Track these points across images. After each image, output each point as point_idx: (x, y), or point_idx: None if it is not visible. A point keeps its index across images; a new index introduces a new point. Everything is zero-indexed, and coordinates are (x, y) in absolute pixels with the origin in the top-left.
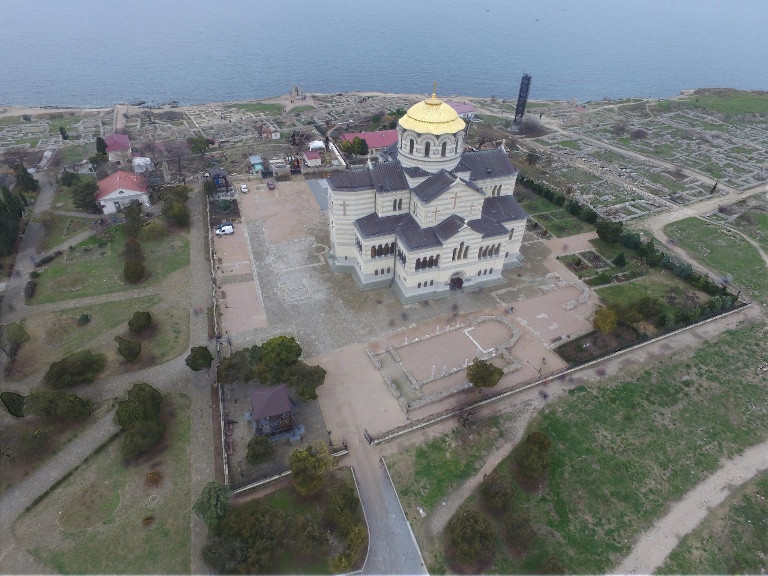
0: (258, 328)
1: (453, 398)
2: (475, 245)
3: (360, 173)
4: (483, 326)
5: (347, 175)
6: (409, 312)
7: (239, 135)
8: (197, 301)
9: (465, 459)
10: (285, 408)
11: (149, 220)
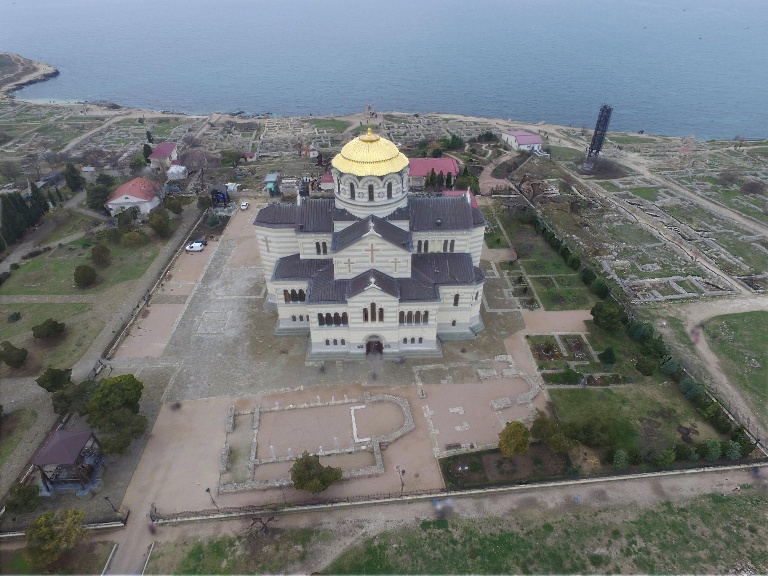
0: (149, 356)
1: (279, 491)
2: (391, 308)
3: (288, 209)
4: (377, 407)
5: (272, 209)
6: (307, 371)
7: (281, 151)
8: None
9: (239, 575)
10: (68, 459)
11: (142, 227)
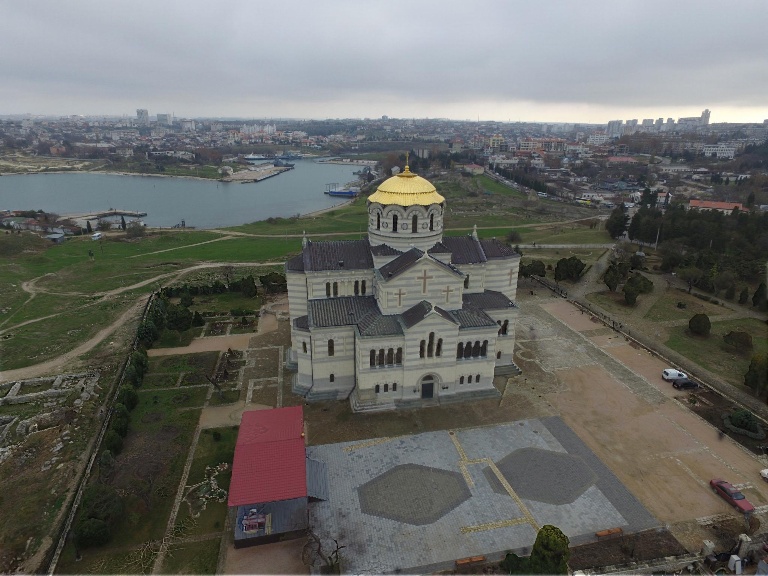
0: None
1: None
2: None
3: None
4: None
5: None
6: None
7: None
8: (612, 317)
9: None
10: None
11: None
